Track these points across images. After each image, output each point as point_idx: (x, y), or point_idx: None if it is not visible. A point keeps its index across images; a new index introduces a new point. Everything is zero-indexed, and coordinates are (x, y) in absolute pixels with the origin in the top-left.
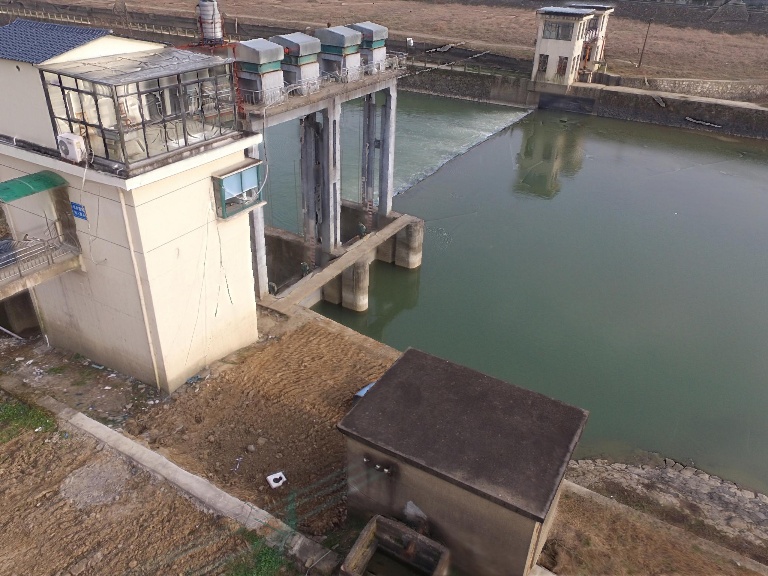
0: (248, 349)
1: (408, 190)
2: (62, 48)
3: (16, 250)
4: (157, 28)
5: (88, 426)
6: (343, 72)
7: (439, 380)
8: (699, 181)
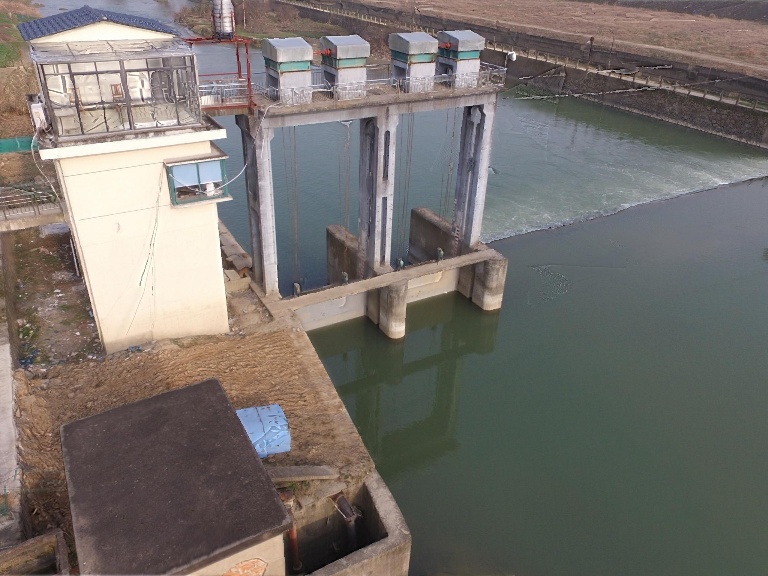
0: (210, 337)
1: (563, 226)
2: (57, 30)
3: (6, 196)
4: None
5: None
6: (407, 81)
7: (195, 420)
8: None
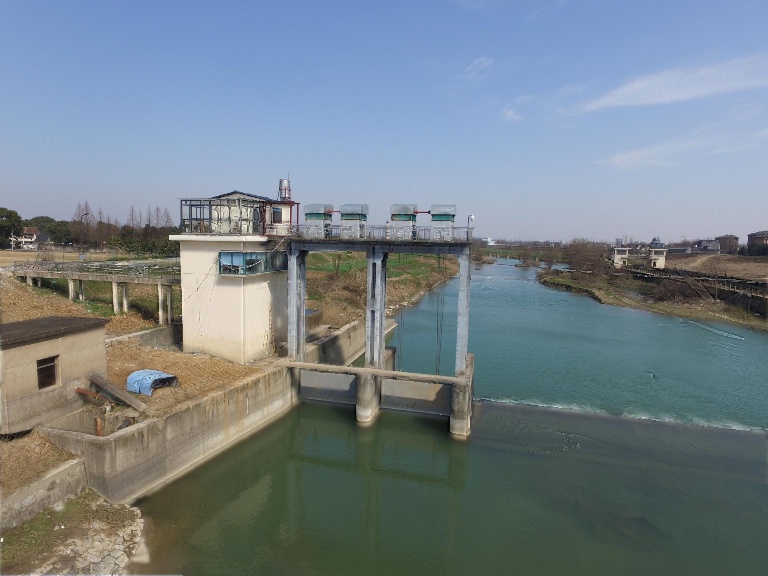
0: (230, 362)
1: (649, 419)
2: None
3: None
4: (738, 288)
5: None
6: None
7: (70, 322)
8: None
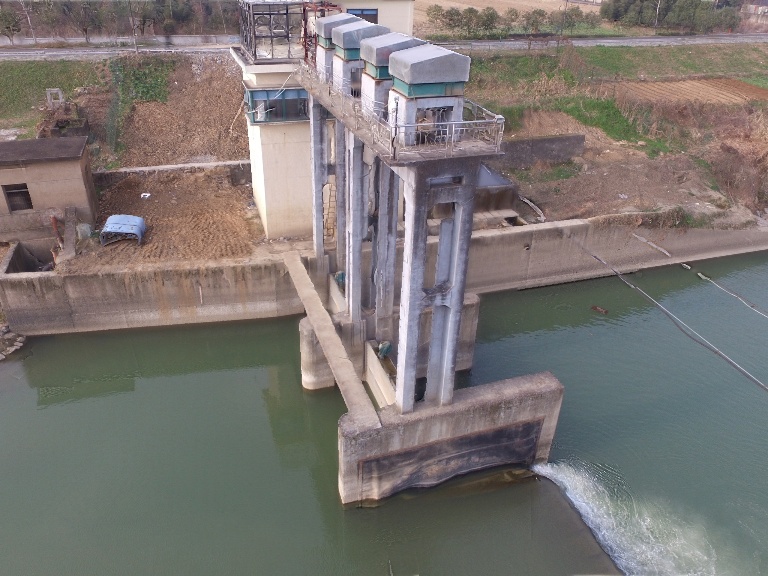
0: (261, 231)
1: None
2: None
3: None
4: None
5: (238, 161)
6: None
7: (51, 152)
8: None
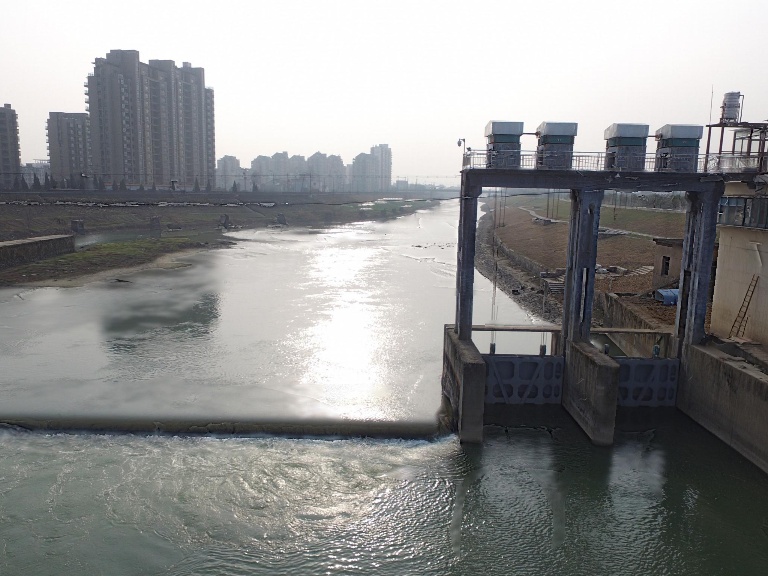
0: None
1: None
2: None
3: None
4: None
5: None
6: None
7: None
8: (51, 322)
